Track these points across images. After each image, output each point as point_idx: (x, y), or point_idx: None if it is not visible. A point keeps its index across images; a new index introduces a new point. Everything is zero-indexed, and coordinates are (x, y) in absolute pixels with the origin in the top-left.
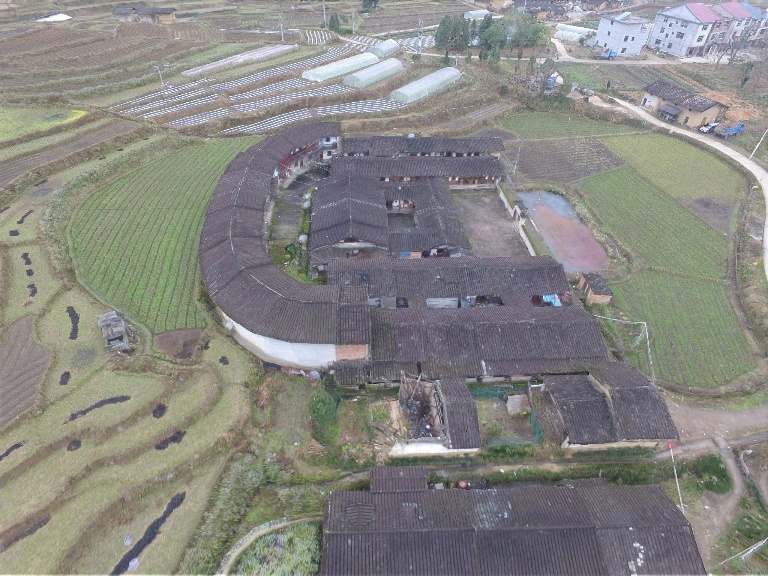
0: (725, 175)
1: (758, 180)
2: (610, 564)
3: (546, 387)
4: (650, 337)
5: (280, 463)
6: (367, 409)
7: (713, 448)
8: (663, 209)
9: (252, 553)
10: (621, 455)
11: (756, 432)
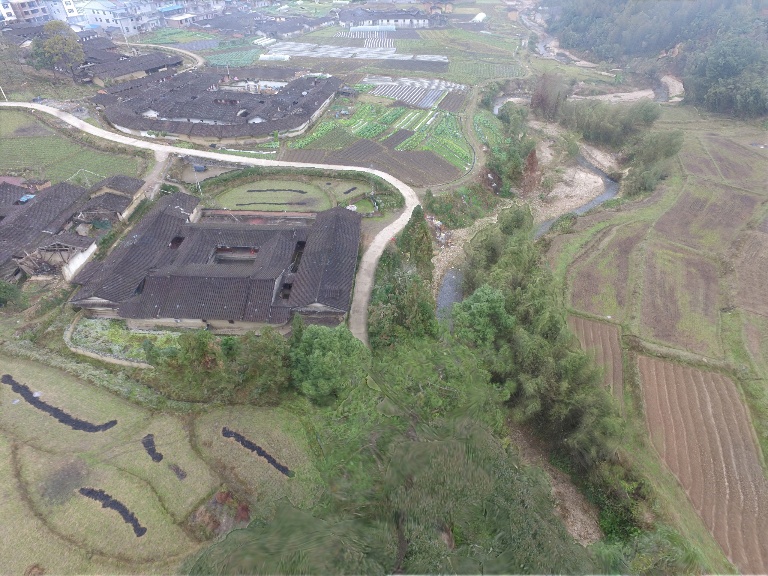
0: (8, 115)
1: (29, 107)
2: (178, 217)
3: (84, 214)
4: (91, 181)
5: (26, 330)
6: (24, 293)
7: (160, 184)
8: (5, 145)
9: (78, 339)
10: (141, 208)
11: (163, 172)
